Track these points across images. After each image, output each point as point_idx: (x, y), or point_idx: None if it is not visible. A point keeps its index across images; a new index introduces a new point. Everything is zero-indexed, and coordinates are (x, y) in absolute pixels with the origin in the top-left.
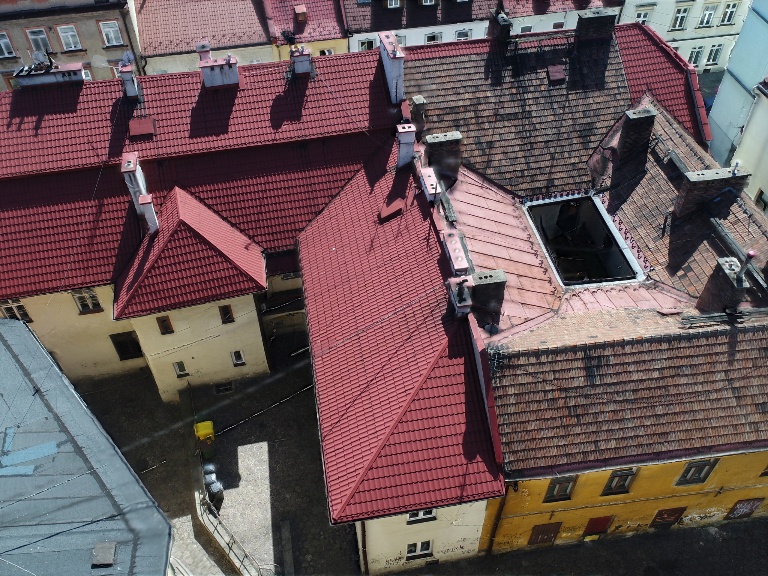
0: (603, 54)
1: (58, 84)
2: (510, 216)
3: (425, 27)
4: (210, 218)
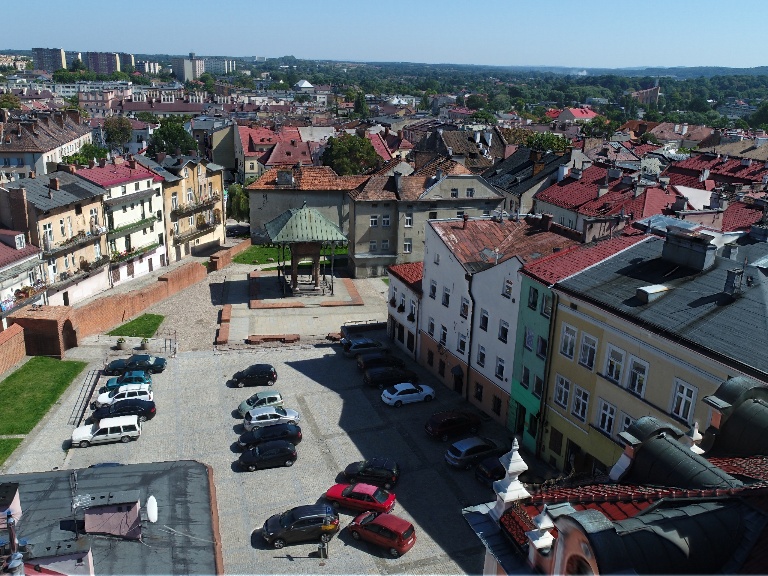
0: None
1: (712, 156)
2: None
3: None
4: (713, 186)
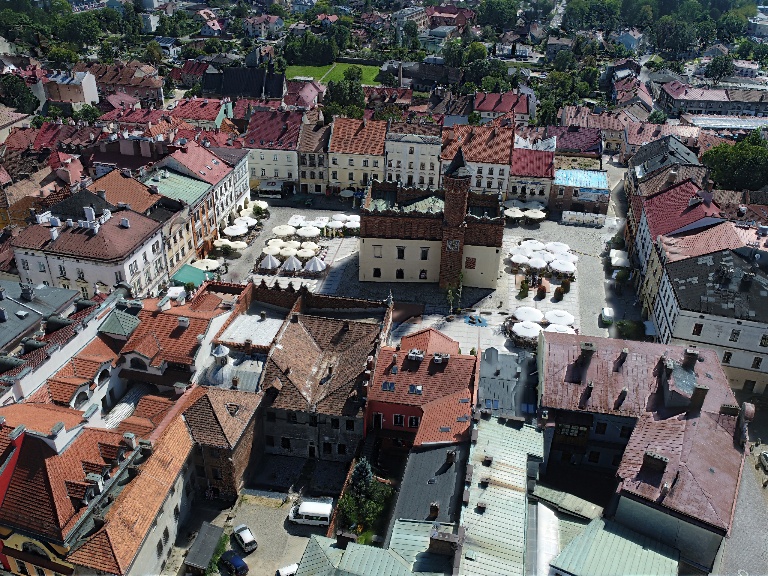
0: (47, 156)
1: None
2: (4, 179)
3: (70, 154)
4: None
